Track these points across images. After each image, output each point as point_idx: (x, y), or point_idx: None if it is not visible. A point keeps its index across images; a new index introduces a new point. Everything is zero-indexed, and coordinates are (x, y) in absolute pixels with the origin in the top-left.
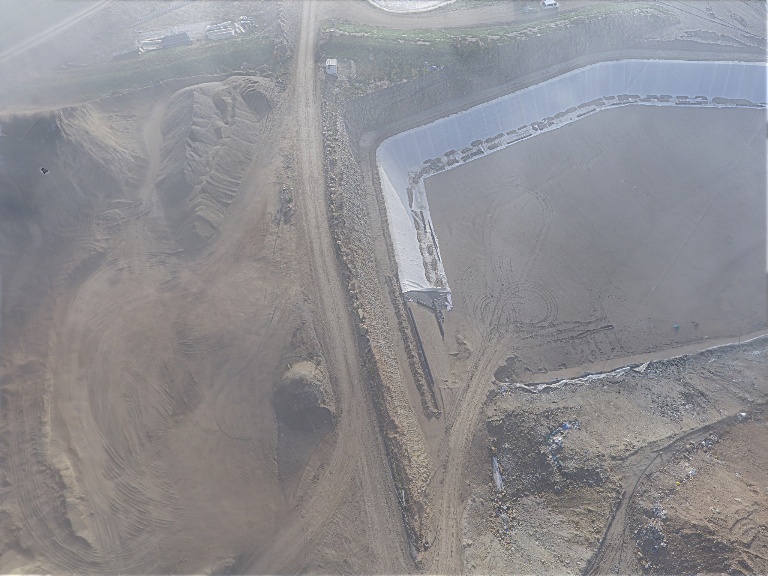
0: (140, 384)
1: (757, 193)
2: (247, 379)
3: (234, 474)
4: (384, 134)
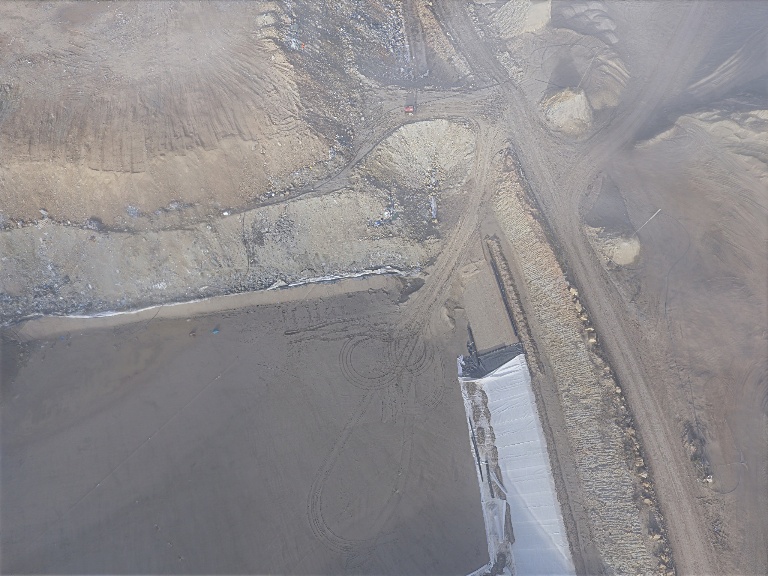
0: (762, 252)
1: None
2: (669, 255)
3: (654, 191)
4: None
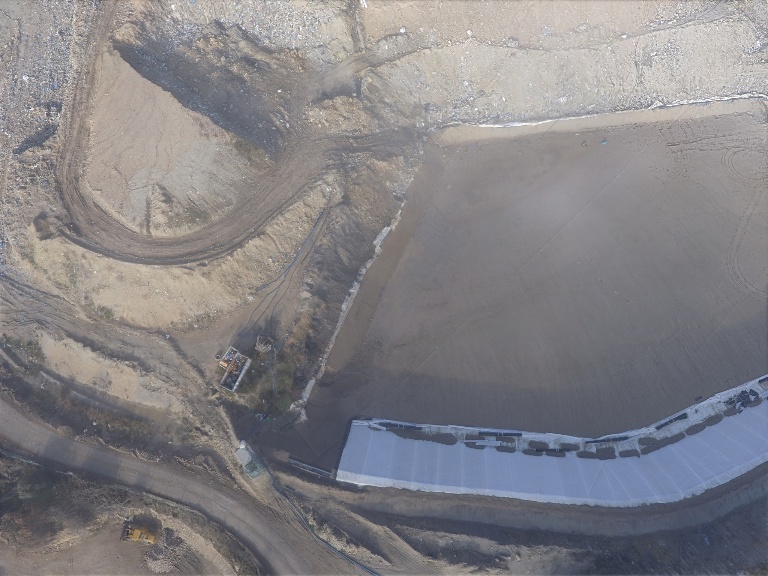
0: None
1: (458, 278)
2: None
3: None
4: None
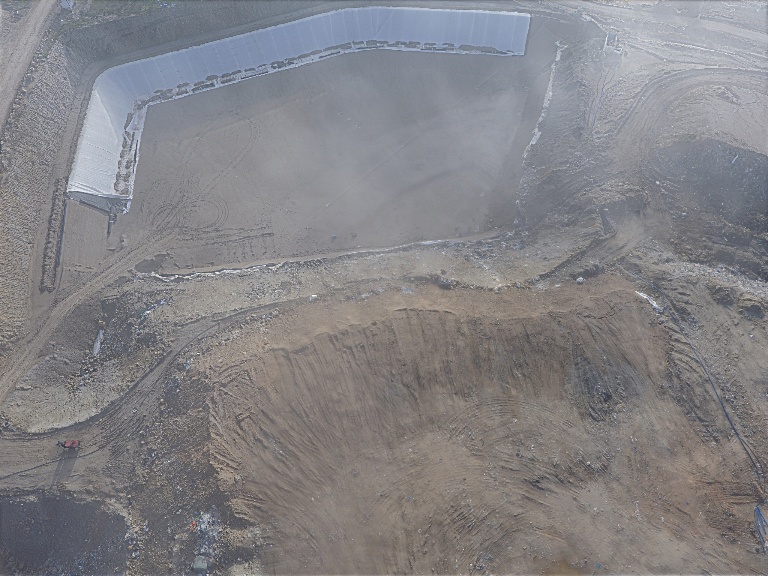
0: None
1: (467, 128)
2: None
3: None
4: (111, 63)
